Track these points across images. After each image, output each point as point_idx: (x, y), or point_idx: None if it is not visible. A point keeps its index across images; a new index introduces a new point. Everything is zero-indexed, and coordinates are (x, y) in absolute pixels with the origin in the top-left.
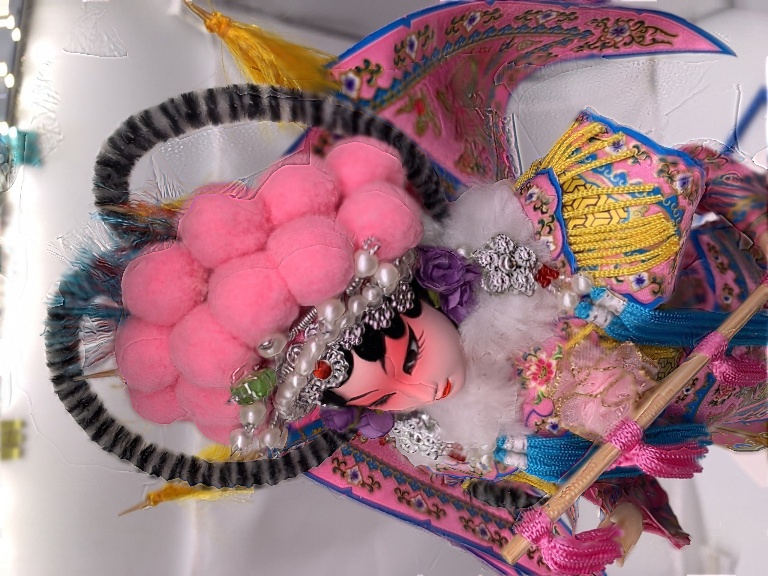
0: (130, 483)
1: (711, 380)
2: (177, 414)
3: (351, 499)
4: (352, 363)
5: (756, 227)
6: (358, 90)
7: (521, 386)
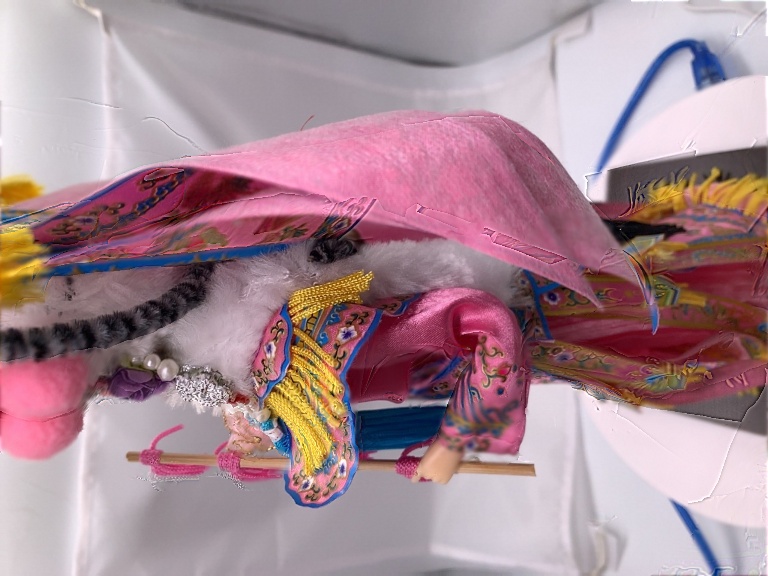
0: None
1: None
2: None
3: None
4: None
5: (443, 434)
6: None
7: None
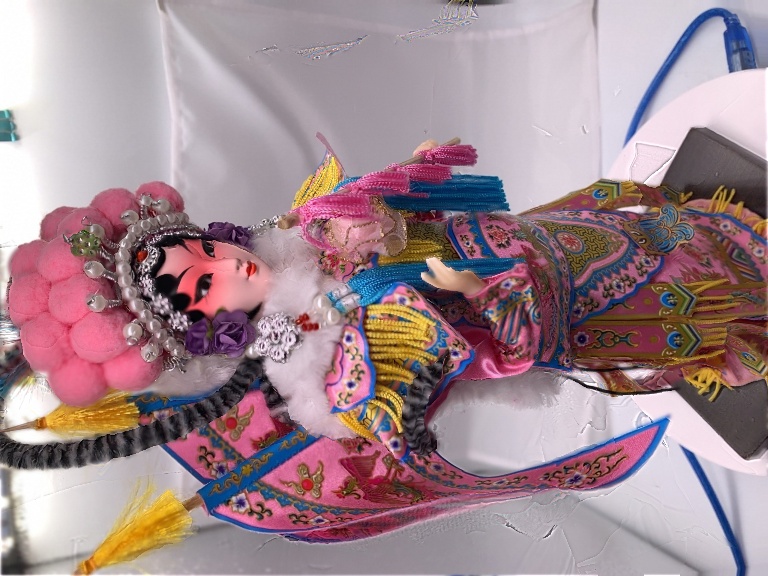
0: (56, 536)
1: (477, 232)
2: (55, 327)
3: (338, 562)
4: (164, 251)
5: None
6: None
7: (329, 274)
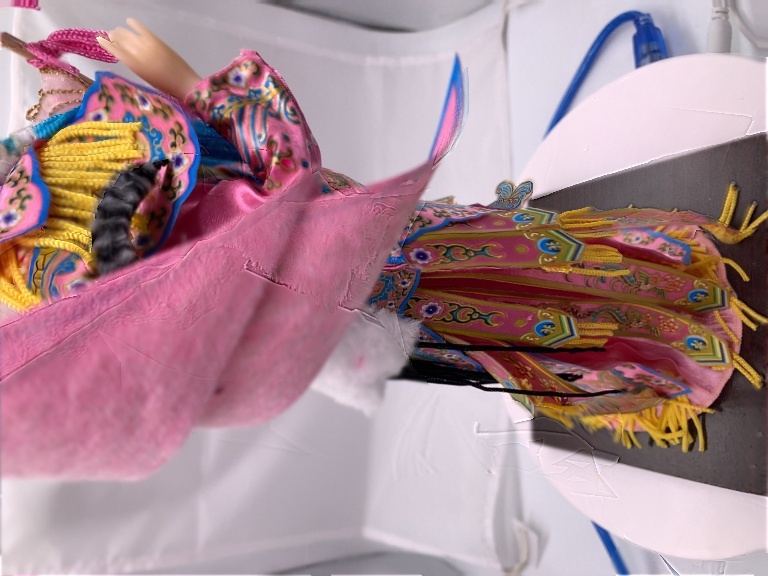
0: None
1: None
2: None
3: None
4: None
5: None
6: None
7: None
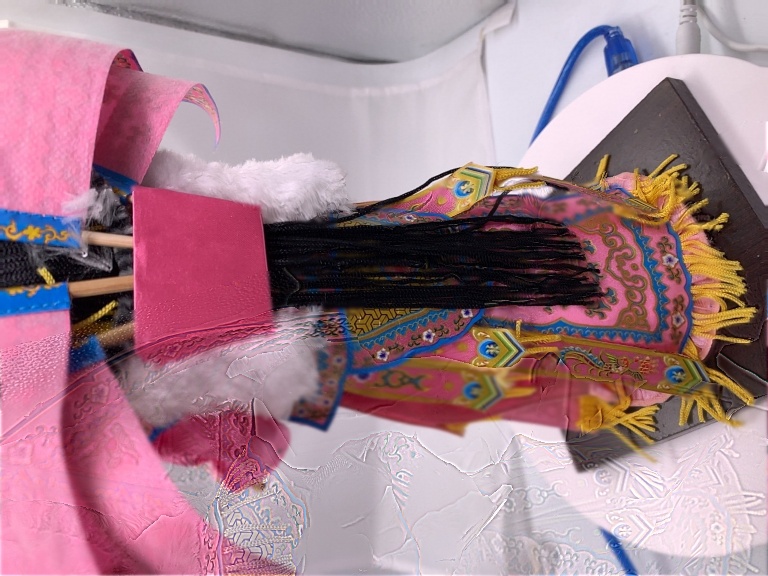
0: None
1: None
2: None
3: None
4: None
5: (415, 531)
6: (30, 456)
7: None
